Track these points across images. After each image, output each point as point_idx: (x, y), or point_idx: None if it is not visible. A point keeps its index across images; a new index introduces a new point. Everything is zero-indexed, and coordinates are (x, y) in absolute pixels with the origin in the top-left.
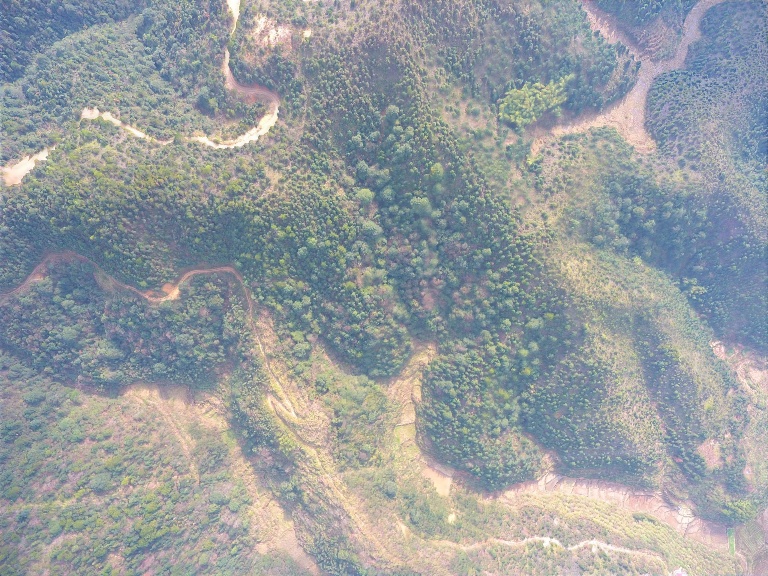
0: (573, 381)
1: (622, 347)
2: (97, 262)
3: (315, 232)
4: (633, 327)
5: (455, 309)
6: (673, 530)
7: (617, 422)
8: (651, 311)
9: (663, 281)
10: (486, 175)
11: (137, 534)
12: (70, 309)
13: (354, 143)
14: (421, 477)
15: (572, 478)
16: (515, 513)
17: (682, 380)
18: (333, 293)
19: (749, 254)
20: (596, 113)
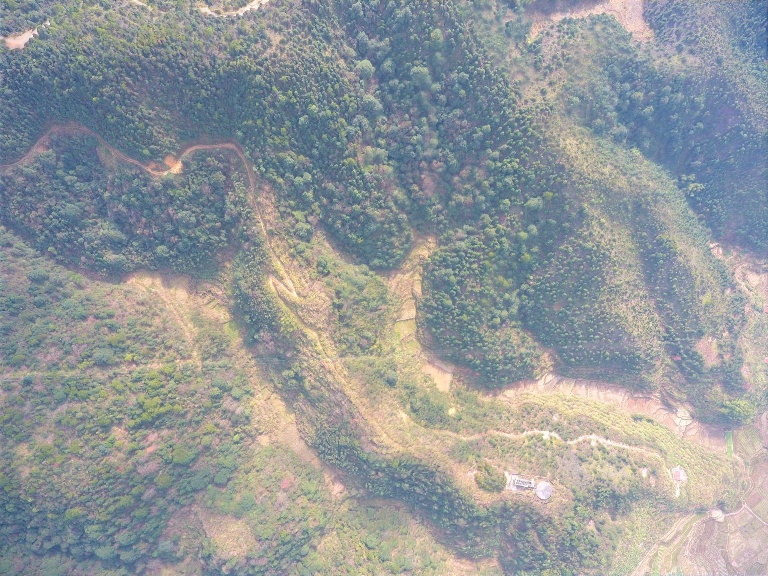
0: (572, 267)
1: (621, 237)
2: (100, 131)
3: (316, 99)
4: (631, 216)
5: (455, 195)
6: (671, 431)
7: (616, 312)
8: (649, 198)
9: None
10: (485, 46)
11: (140, 408)
12: (73, 185)
13: (354, 11)
14: (421, 373)
15: (571, 379)
16: (515, 410)
17: (680, 273)
18: (334, 172)
19: (747, 145)
20: (595, 2)
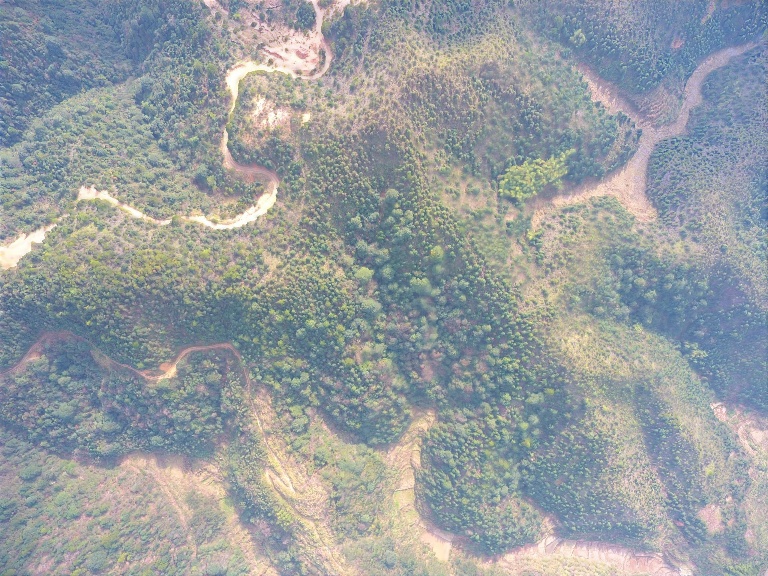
0: (573, 452)
1: (623, 416)
2: (94, 343)
3: (314, 314)
4: (634, 396)
5: (455, 380)
6: None
7: (618, 491)
8: (652, 381)
9: (664, 346)
10: (486, 255)
11: None
12: (66, 386)
13: (353, 224)
14: (420, 542)
15: (572, 540)
16: None
17: (683, 447)
18: (332, 368)
19: (751, 322)
20: (597, 182)
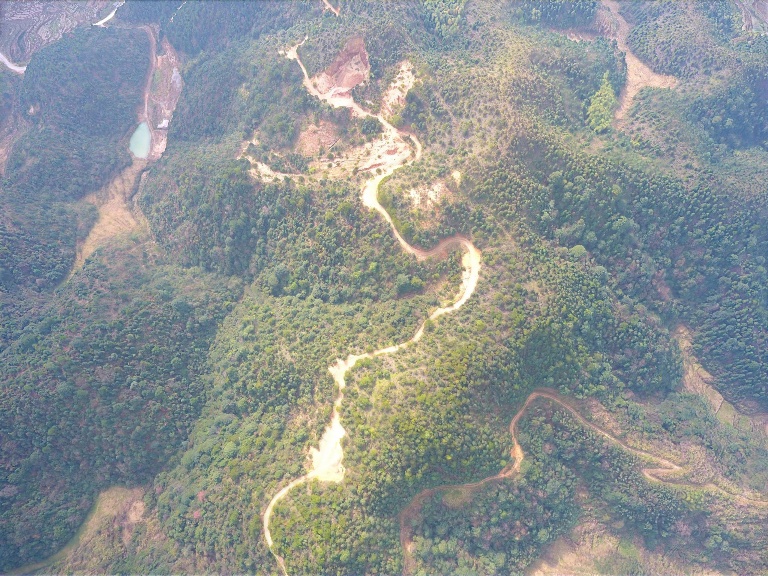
0: None
1: None
2: (451, 481)
3: None
4: None
5: (682, 283)
6: None
7: None
8: None
9: None
10: None
11: None
12: (447, 550)
13: (545, 221)
14: None
15: None
16: None
17: None
18: (613, 345)
19: None
20: (624, 88)
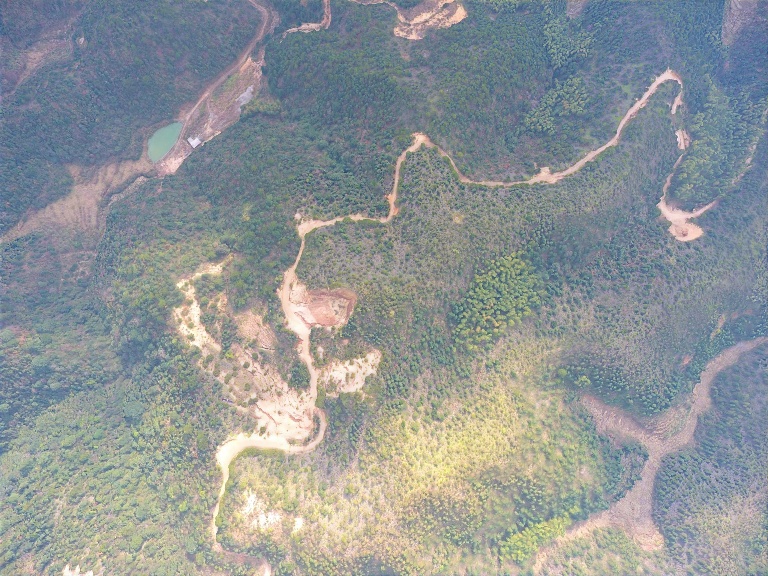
0: None
1: None
2: None
3: None
4: None
5: None
6: None
7: None
8: None
9: None
10: None
11: None
12: None
13: None
14: None
15: None
16: None
17: None
18: None
19: None
20: None
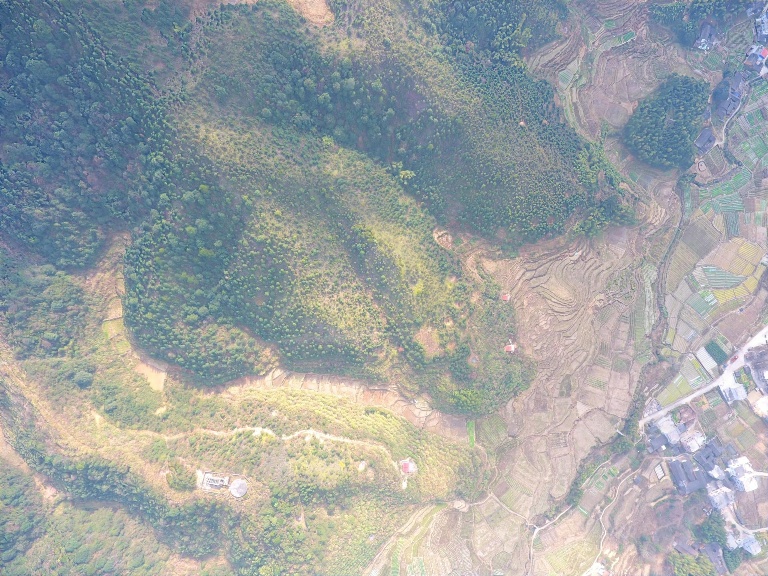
0: (254, 261)
1: (312, 228)
2: None
3: None
4: (321, 207)
5: None
6: (408, 423)
7: (313, 305)
8: (331, 188)
9: (365, 164)
10: (105, 36)
11: None
12: None
13: None
14: (133, 372)
15: (301, 373)
16: (235, 407)
17: (384, 263)
18: None
19: (440, 130)
20: None
